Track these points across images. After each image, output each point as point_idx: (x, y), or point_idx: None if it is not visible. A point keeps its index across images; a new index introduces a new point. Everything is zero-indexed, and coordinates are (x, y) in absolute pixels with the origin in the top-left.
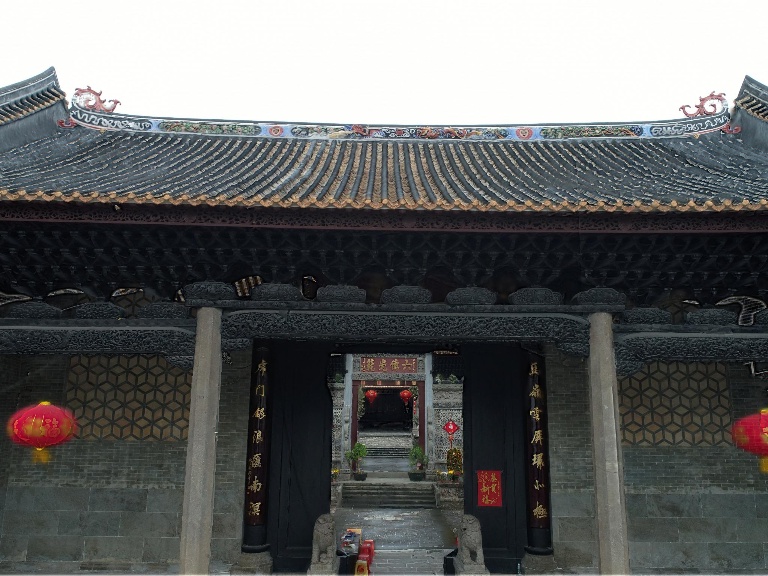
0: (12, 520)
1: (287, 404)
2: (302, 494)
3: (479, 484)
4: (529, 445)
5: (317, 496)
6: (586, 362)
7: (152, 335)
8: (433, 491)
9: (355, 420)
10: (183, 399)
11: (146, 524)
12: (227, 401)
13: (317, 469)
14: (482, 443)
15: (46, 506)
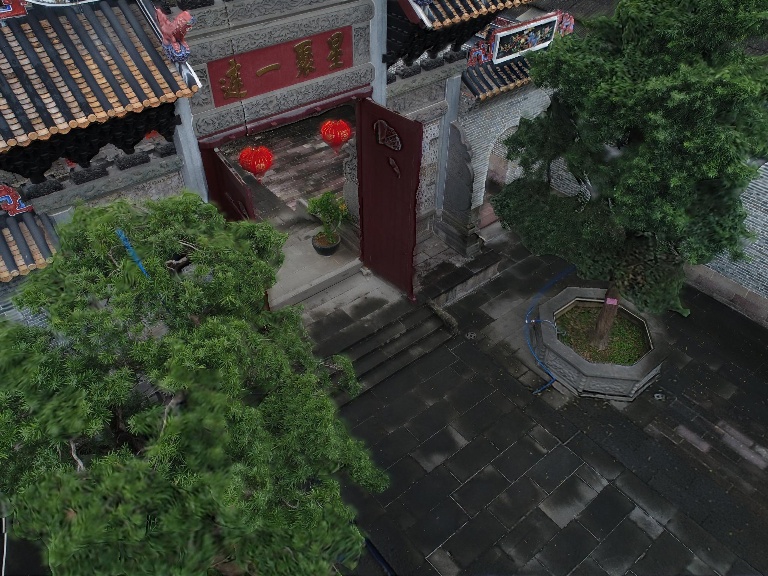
0: None
1: None
2: None
3: None
4: None
5: None
6: None
7: None
8: None
9: None
10: None
11: None
12: None
13: None
14: None
15: None
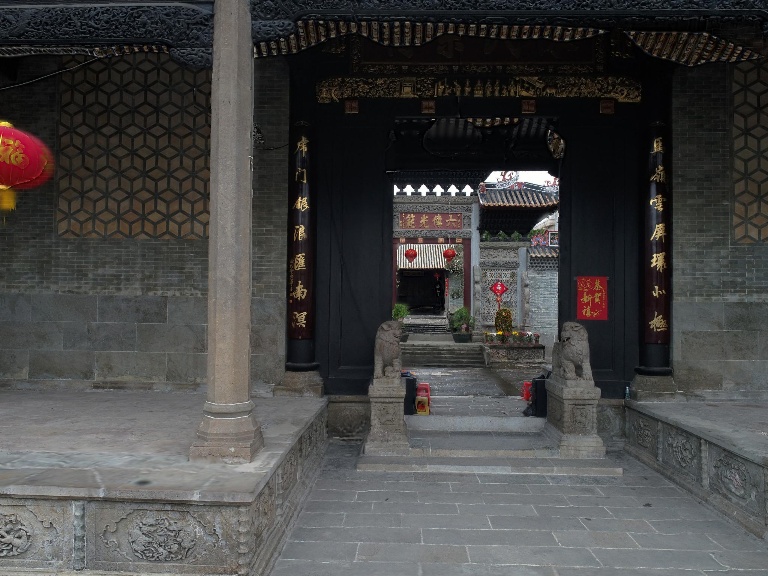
0: (7, 332)
1: (335, 195)
2: (357, 305)
3: (579, 293)
4: (647, 243)
5: (375, 307)
6: (727, 137)
7: (149, 13)
8: (481, 351)
9: (394, 281)
10: (204, 188)
11: (168, 337)
12: (259, 190)
13: (375, 275)
14: (584, 243)
15: (46, 316)
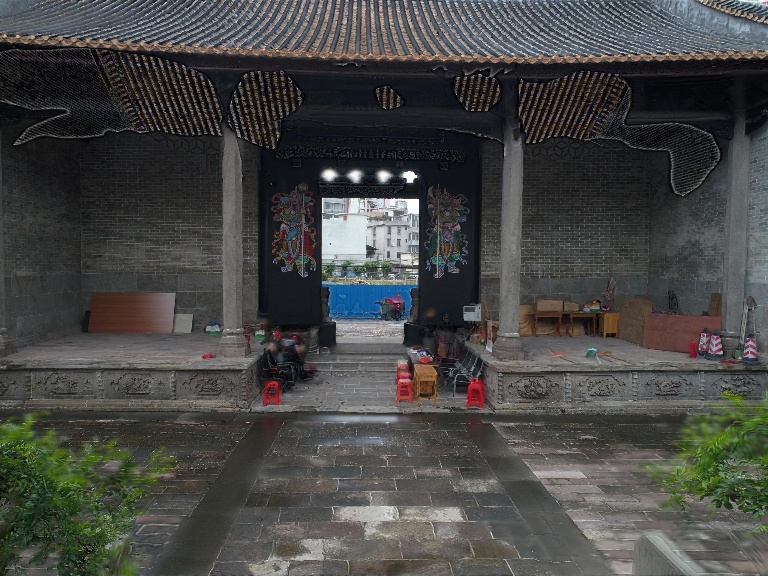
0: None
1: None
2: None
3: None
4: None
5: None
6: None
7: None
8: None
9: None
10: None
11: None
12: None
13: None
14: None
15: None
